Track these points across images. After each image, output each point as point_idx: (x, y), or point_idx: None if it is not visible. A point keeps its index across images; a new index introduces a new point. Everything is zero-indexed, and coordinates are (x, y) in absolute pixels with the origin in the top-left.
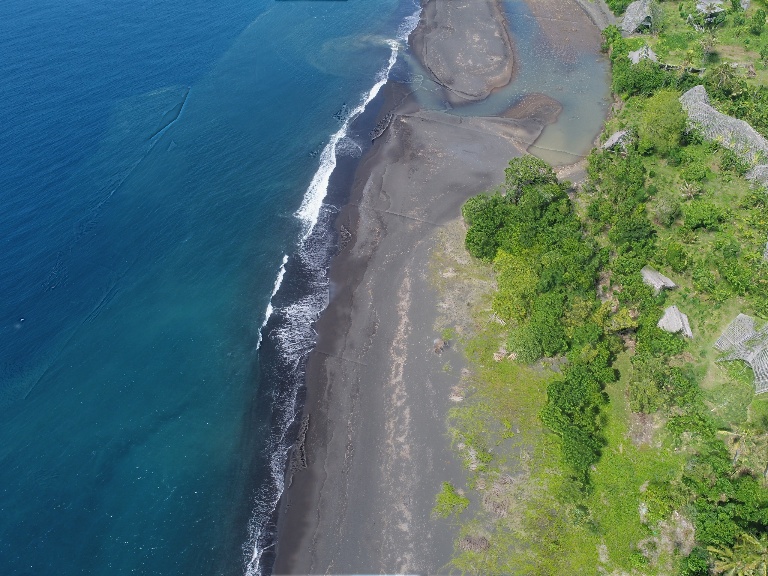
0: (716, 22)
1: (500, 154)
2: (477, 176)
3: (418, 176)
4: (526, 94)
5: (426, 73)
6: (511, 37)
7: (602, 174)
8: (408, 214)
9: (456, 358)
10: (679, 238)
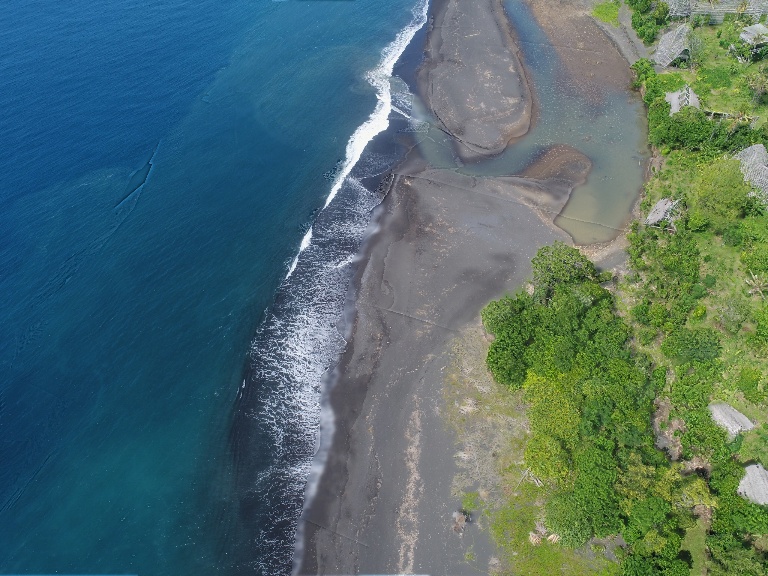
0: (763, 53)
1: (522, 228)
2: (496, 259)
3: (426, 260)
4: (549, 146)
5: (432, 120)
6: (528, 72)
7: (646, 257)
8: (415, 314)
9: (481, 540)
10: (749, 350)
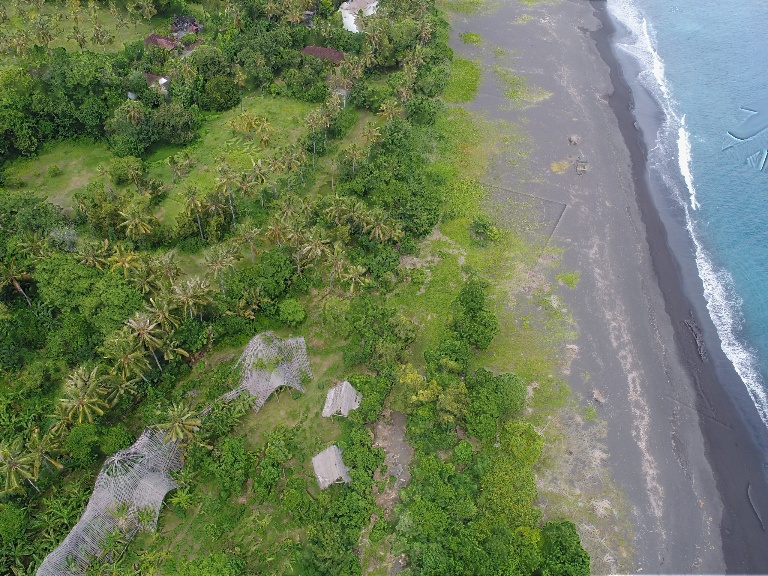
0: None
1: None
2: None
3: None
4: None
5: None
6: None
7: None
8: None
9: (578, 385)
10: None
